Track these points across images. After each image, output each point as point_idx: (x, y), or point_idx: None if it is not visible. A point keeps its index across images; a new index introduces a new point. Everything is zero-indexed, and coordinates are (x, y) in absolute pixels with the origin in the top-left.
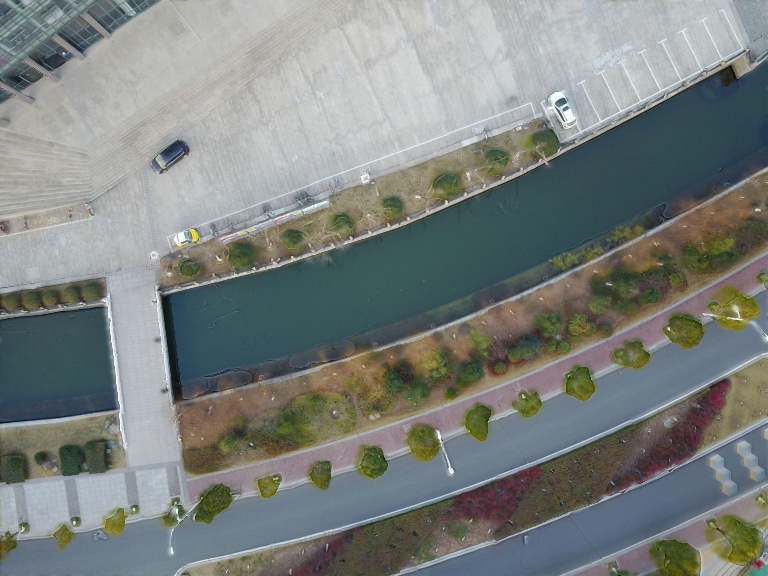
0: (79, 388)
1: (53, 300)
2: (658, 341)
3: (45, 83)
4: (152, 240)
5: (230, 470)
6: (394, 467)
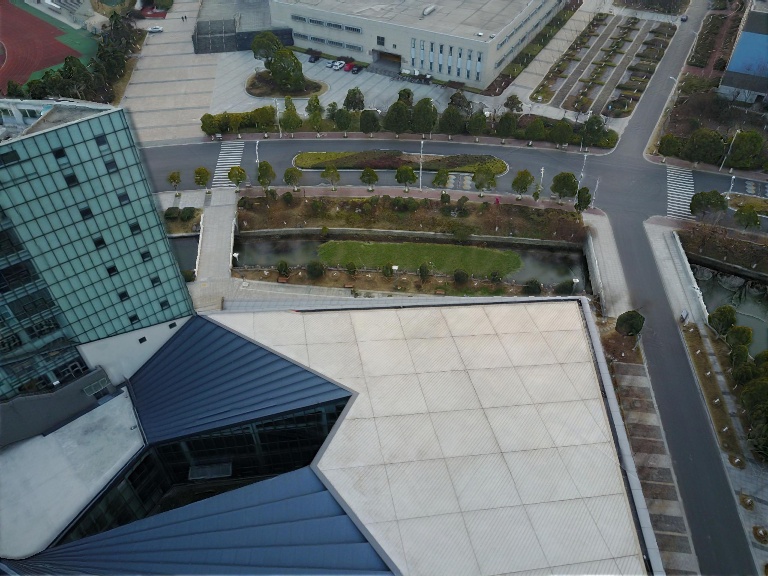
0: None
1: None
2: None
3: None
4: None
5: None
6: None
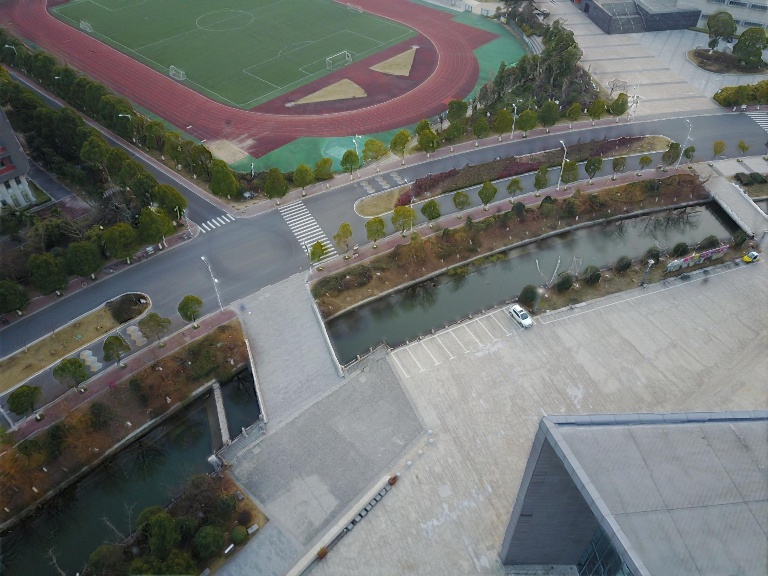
0: None
1: None
2: (437, 223)
3: None
4: None
5: None
6: (577, 178)
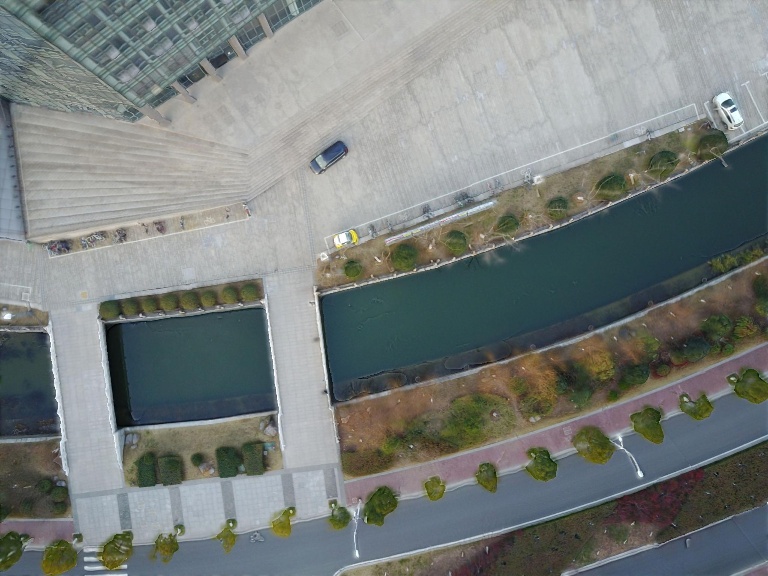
0: (230, 389)
1: (212, 301)
2: None
3: (207, 83)
4: (309, 241)
5: (388, 472)
6: None
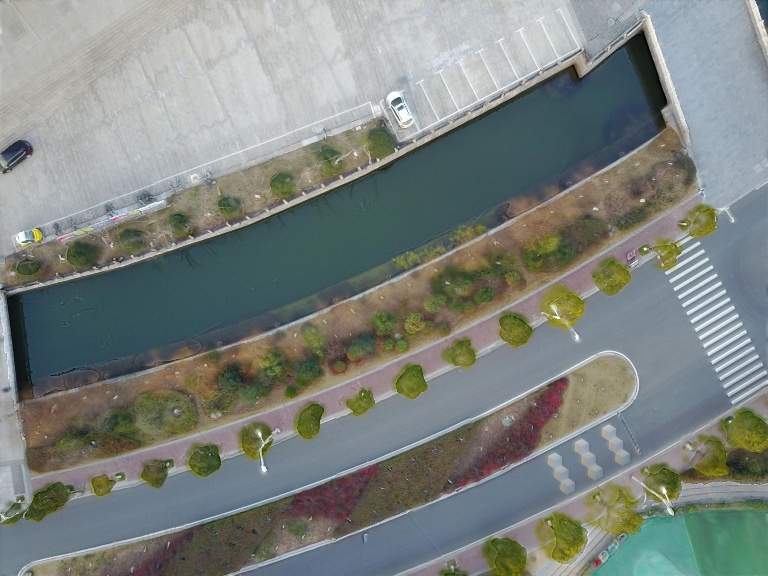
0: None
1: None
2: (497, 340)
3: None
4: None
5: (73, 468)
6: (235, 465)
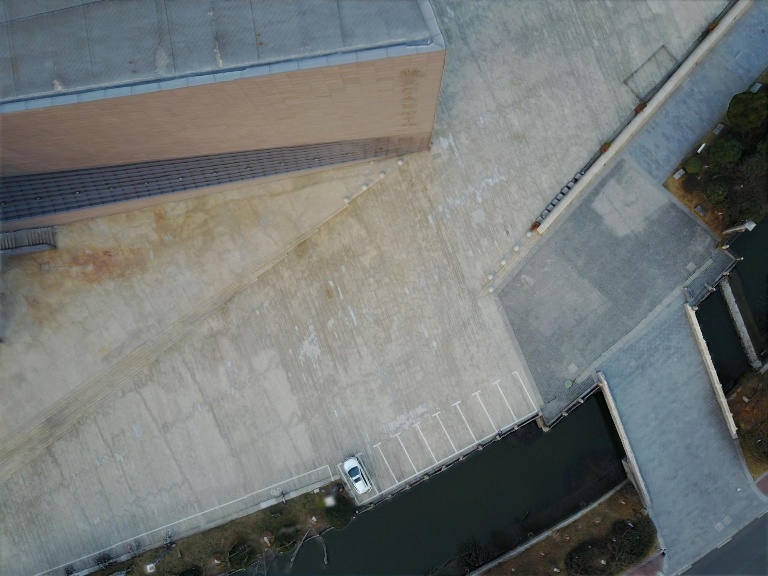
0: None
1: None
2: None
3: None
4: None
5: None
6: None
